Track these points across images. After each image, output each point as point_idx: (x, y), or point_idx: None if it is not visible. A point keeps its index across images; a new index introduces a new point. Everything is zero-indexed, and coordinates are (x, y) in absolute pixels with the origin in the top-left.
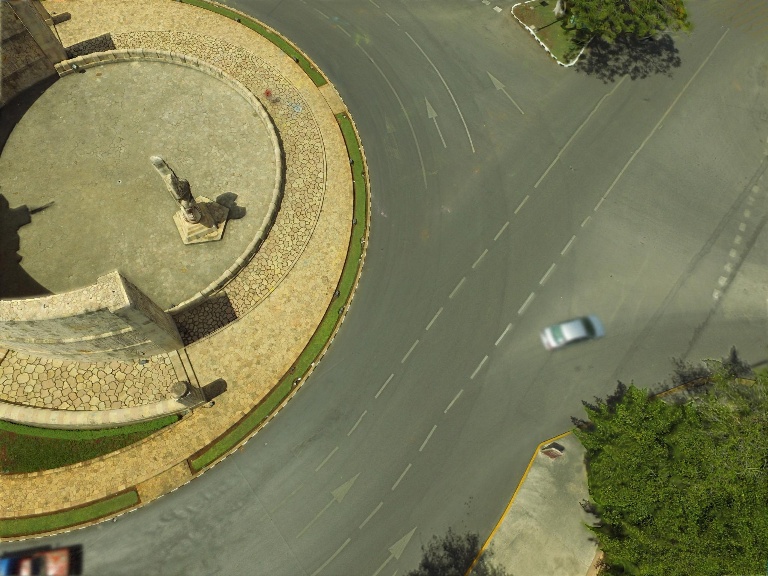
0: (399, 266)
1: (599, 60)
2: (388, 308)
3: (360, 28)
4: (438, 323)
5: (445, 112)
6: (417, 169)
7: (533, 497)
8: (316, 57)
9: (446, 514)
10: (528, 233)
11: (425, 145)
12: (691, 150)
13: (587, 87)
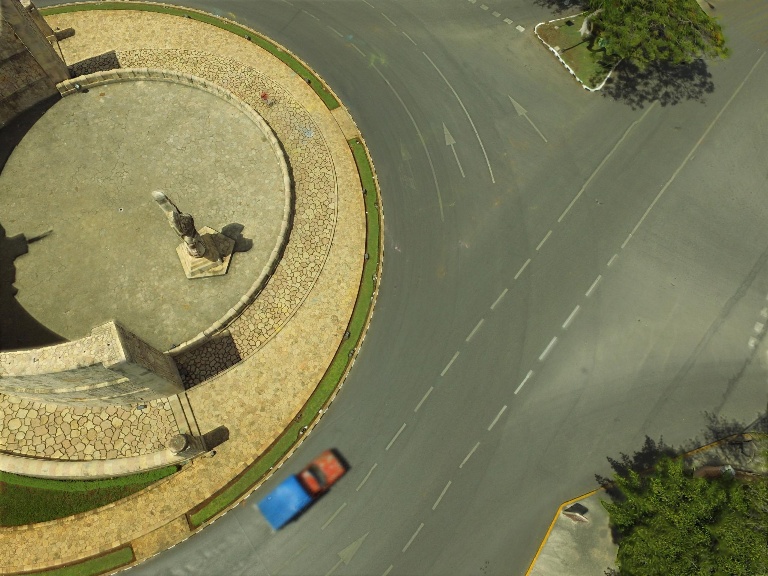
0: (413, 305)
1: (627, 84)
2: (401, 351)
3: (375, 47)
4: (454, 369)
5: (464, 139)
6: (433, 200)
7: (554, 564)
8: (329, 78)
9: None
10: (551, 272)
11: (442, 174)
12: (725, 183)
13: (614, 113)
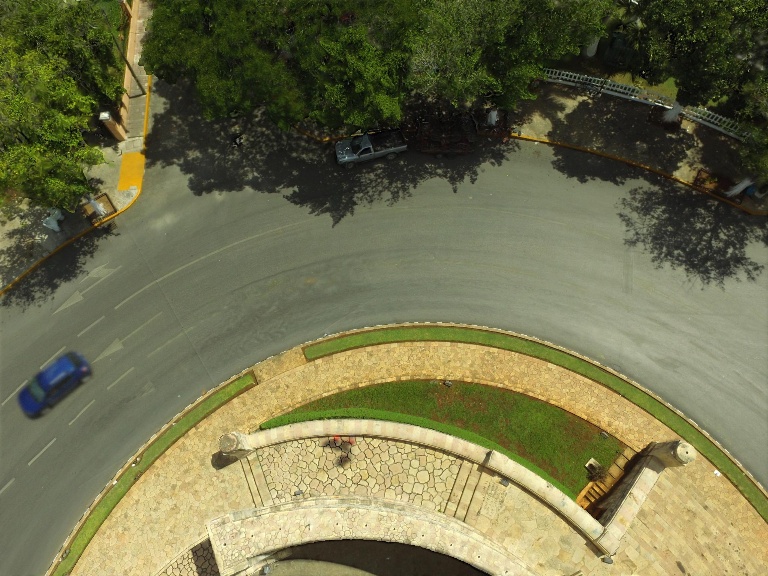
0: None
1: None
2: (8, 554)
3: None
4: None
5: None
6: None
7: None
8: None
9: (22, 323)
10: None
11: None
12: None
13: None
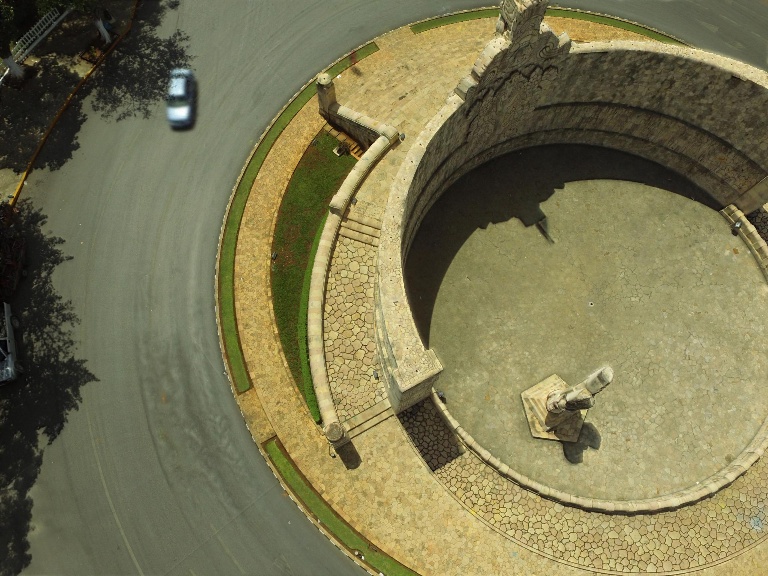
0: None
1: None
2: None
3: None
4: None
5: None
6: None
7: None
8: None
9: None
10: None
11: None
12: None
13: None
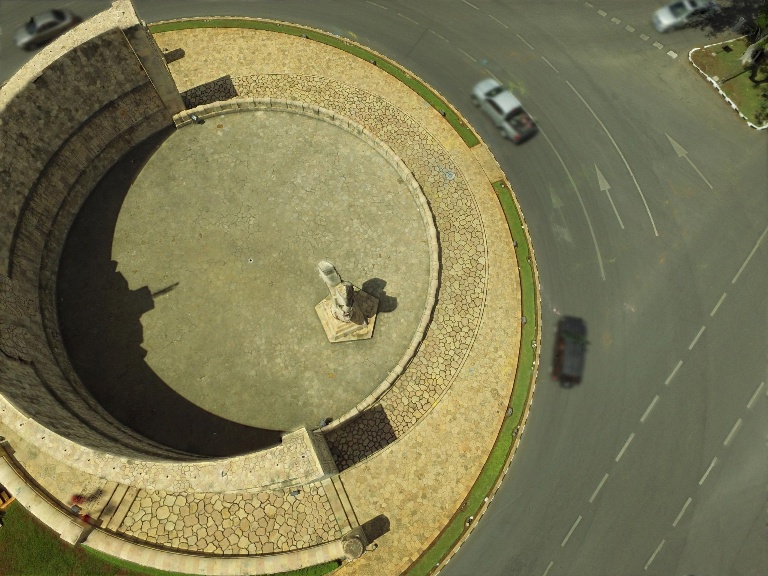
0: (579, 378)
1: None
2: (569, 431)
3: (513, 74)
4: (630, 453)
5: (619, 183)
6: (591, 255)
7: None
8: (465, 110)
9: None
10: (729, 342)
11: (599, 225)
12: None
13: None
